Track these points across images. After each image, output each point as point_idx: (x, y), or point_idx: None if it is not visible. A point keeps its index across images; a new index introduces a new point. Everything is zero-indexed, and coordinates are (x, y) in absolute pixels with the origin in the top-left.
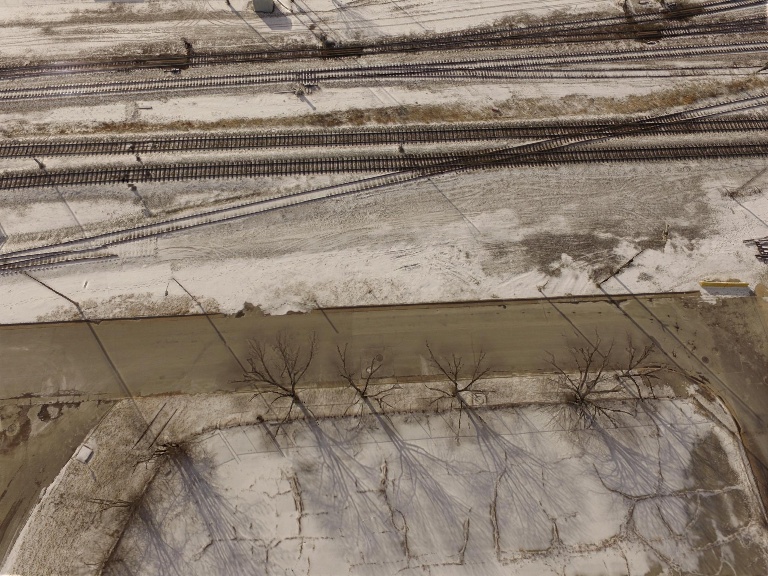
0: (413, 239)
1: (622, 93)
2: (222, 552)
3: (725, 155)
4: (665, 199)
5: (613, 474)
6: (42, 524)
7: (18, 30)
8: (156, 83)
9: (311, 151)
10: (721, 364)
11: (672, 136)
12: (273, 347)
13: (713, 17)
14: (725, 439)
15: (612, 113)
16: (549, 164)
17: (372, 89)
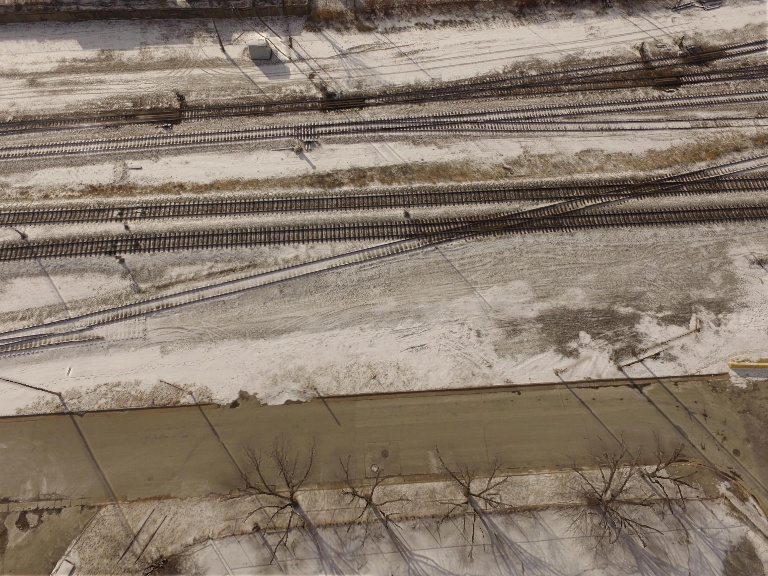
0: (420, 316)
1: (640, 147)
2: None
3: (752, 218)
4: (689, 268)
5: None
6: None
7: (1, 81)
8: (146, 140)
9: (311, 217)
10: (754, 458)
11: (695, 196)
12: (270, 453)
13: (735, 61)
14: (760, 546)
15: (630, 170)
16: (564, 229)
17: (375, 145)
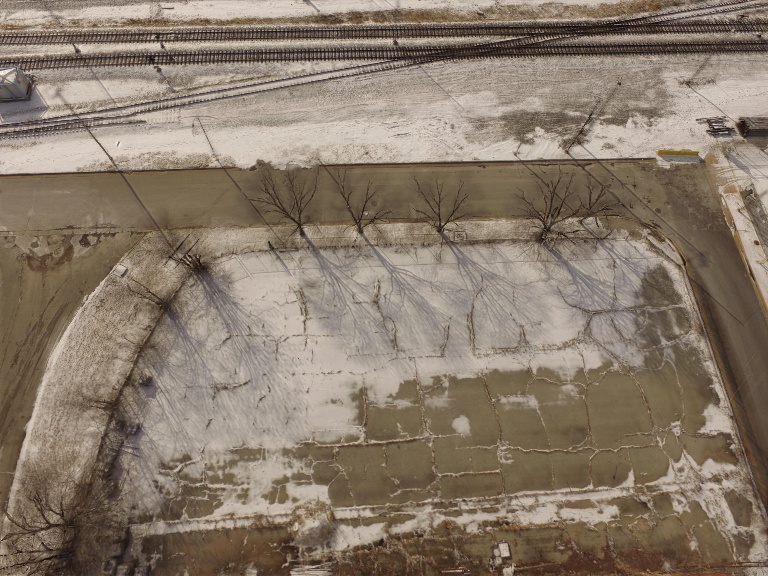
0: (405, 114)
1: (594, 2)
2: (239, 344)
3: (684, 51)
4: (629, 86)
5: (574, 294)
6: (86, 321)
7: None
8: None
9: (315, 43)
10: (672, 214)
11: (637, 36)
12: (283, 181)
13: None
14: (672, 270)
15: (584, 17)
16: (527, 56)
17: None
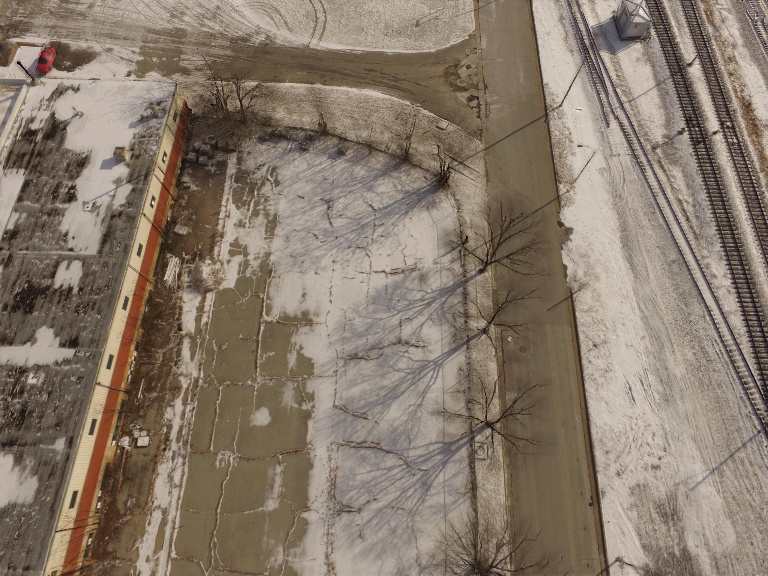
0: (668, 401)
1: None
2: (367, 217)
3: None
4: None
5: None
6: (398, 107)
7: None
8: None
9: (767, 291)
10: None
11: None
12: None
13: None
14: None
15: None
16: None
17: None
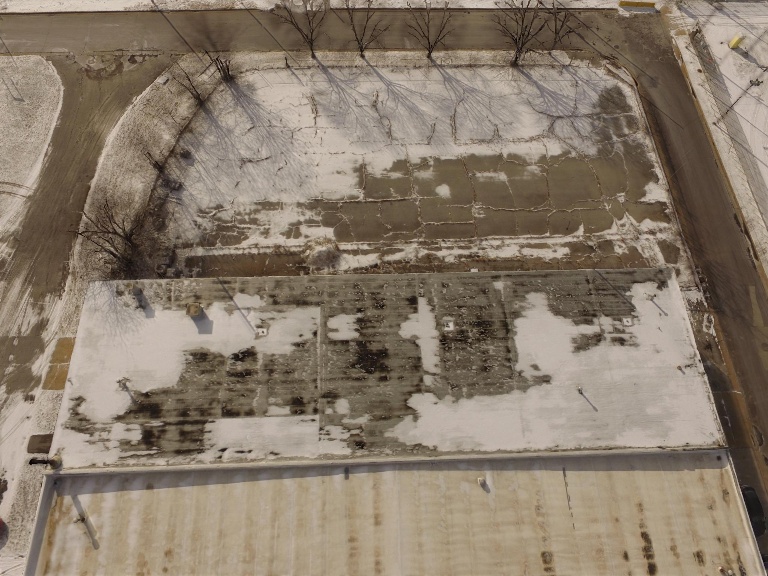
0: None
1: None
2: (261, 132)
3: None
4: None
5: (541, 104)
6: (135, 114)
7: None
8: None
9: None
10: (628, 49)
11: None
12: (298, 6)
13: None
14: (625, 89)
15: None
16: None
17: None
